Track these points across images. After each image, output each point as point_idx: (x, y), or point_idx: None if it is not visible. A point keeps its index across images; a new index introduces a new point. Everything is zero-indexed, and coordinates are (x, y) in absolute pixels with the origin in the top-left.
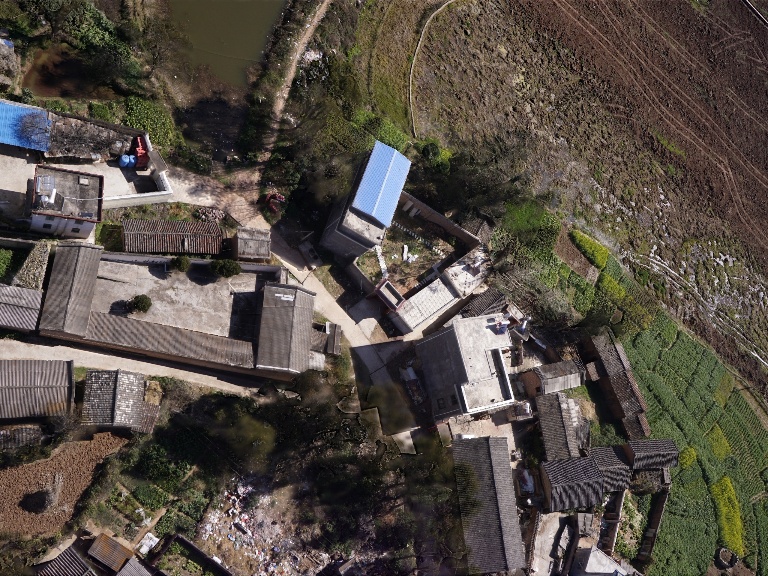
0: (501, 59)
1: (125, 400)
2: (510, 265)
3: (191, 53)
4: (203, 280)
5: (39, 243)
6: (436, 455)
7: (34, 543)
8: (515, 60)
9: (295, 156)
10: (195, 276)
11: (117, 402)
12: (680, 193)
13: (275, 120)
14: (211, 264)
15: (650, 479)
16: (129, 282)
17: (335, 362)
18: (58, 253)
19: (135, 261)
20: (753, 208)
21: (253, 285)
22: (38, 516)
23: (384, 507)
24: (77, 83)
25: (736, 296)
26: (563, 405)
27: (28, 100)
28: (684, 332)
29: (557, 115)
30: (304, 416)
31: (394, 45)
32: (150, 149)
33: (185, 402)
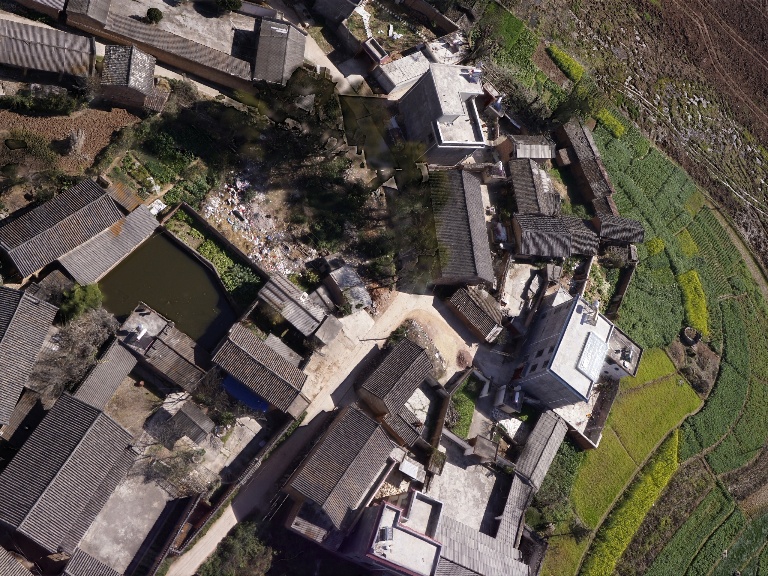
0: None
1: (138, 71)
2: (487, 50)
3: None
4: (208, 14)
5: None
6: None
7: (60, 171)
8: None
9: None
10: (201, 9)
11: (132, 70)
12: (656, 38)
13: None
14: None
15: (618, 253)
16: (143, 3)
17: None
18: None
19: None
20: (728, 62)
21: (252, 26)
22: (64, 158)
23: (367, 224)
24: None
25: (709, 133)
26: (534, 170)
27: None
28: (656, 150)
29: None
30: (296, 136)
31: None
32: None
33: (191, 101)
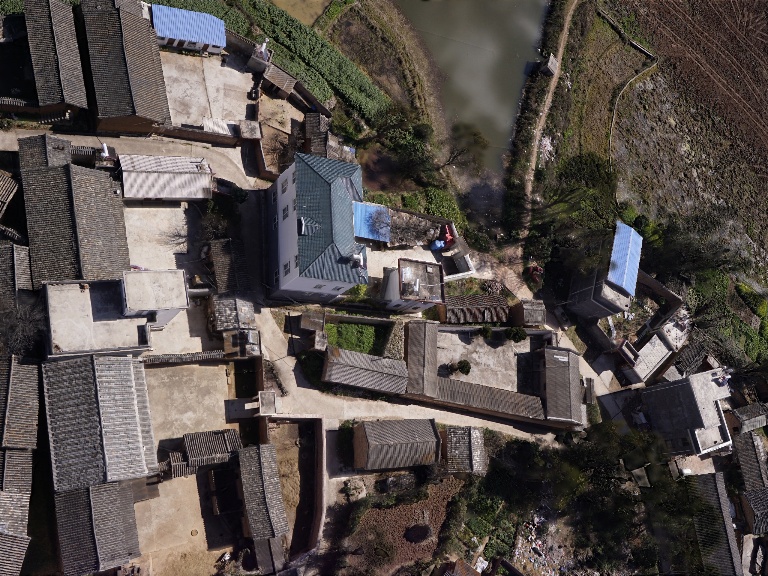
0: (672, 130)
1: (476, 451)
2: (707, 321)
3: (462, 145)
4: (495, 344)
5: (397, 321)
6: (665, 487)
7: (423, 568)
8: (682, 130)
9: (548, 233)
10: (489, 341)
11: (472, 453)
12: None
13: (528, 201)
14: (506, 331)
15: None
16: (447, 348)
17: (588, 410)
18: (411, 329)
19: (450, 330)
20: None
21: (528, 346)
22: (417, 545)
23: (633, 532)
24: (390, 177)
25: None
26: (755, 442)
27: (365, 196)
28: None
29: (716, 178)
30: None
31: (595, 124)
32: (457, 235)
33: (497, 448)
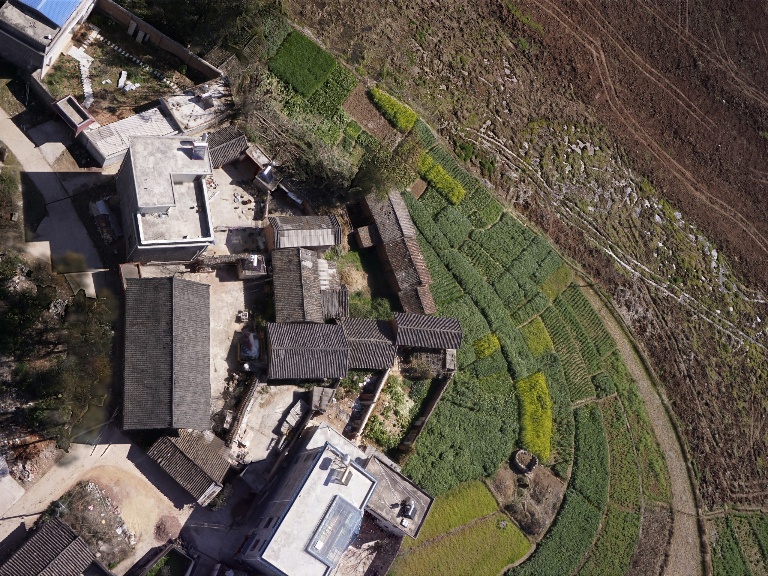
0: None
1: None
2: (256, 103)
3: None
4: None
5: None
6: (123, 302)
7: None
8: None
9: None
10: None
11: None
12: (532, 70)
13: None
14: None
15: (427, 362)
16: None
17: None
18: None
19: None
20: (628, 97)
21: None
22: None
23: (36, 351)
24: None
25: (593, 187)
26: (306, 263)
27: None
28: (512, 215)
29: None
30: None
31: None
32: None
33: None
